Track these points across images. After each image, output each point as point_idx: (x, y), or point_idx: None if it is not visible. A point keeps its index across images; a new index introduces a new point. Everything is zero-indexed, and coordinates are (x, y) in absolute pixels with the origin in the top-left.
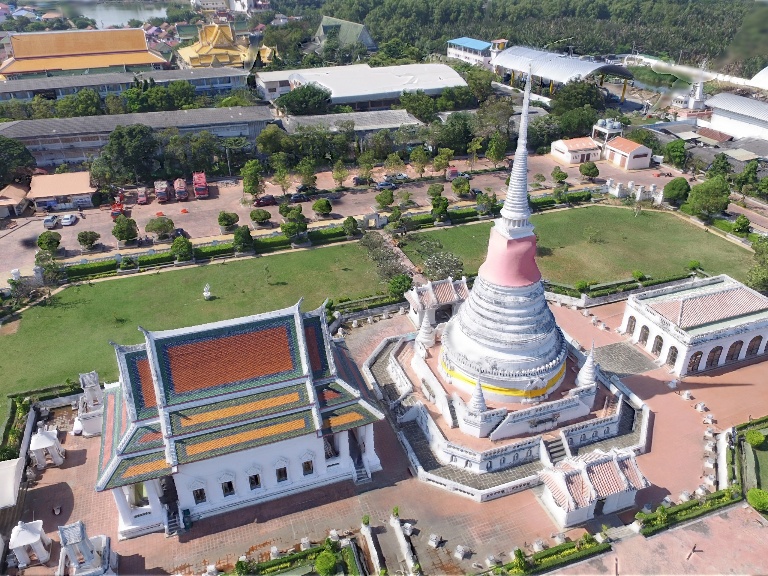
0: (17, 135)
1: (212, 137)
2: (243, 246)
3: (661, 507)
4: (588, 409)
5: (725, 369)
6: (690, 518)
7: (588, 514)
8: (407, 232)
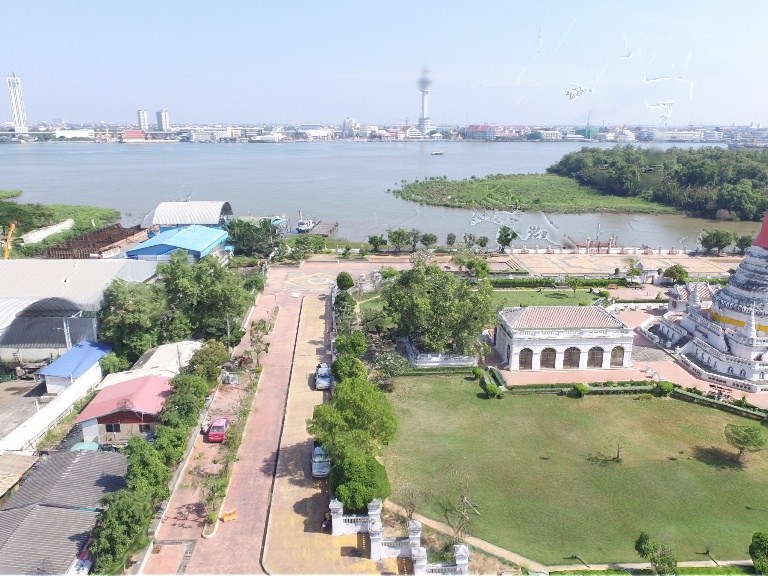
0: None
1: None
2: None
3: None
4: None
5: None
6: None
7: None
8: None
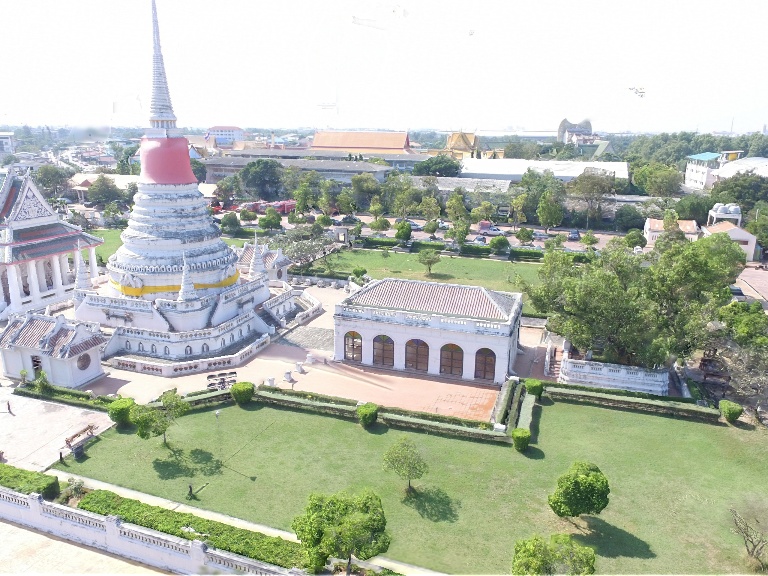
0: (211, 163)
1: (320, 177)
2: (230, 230)
3: (41, 372)
4: (166, 324)
5: (395, 373)
6: (65, 402)
7: (28, 373)
8: (362, 248)
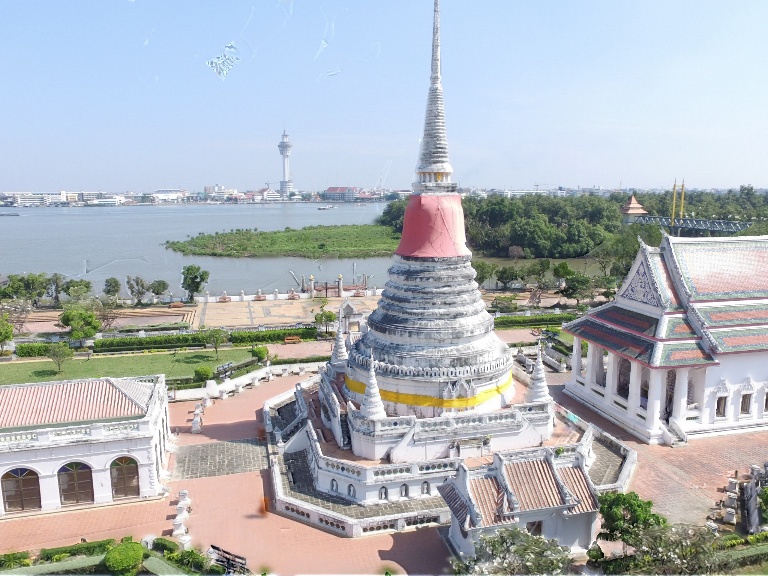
0: None
1: None
2: None
3: None
4: None
5: None
6: None
7: None
8: None
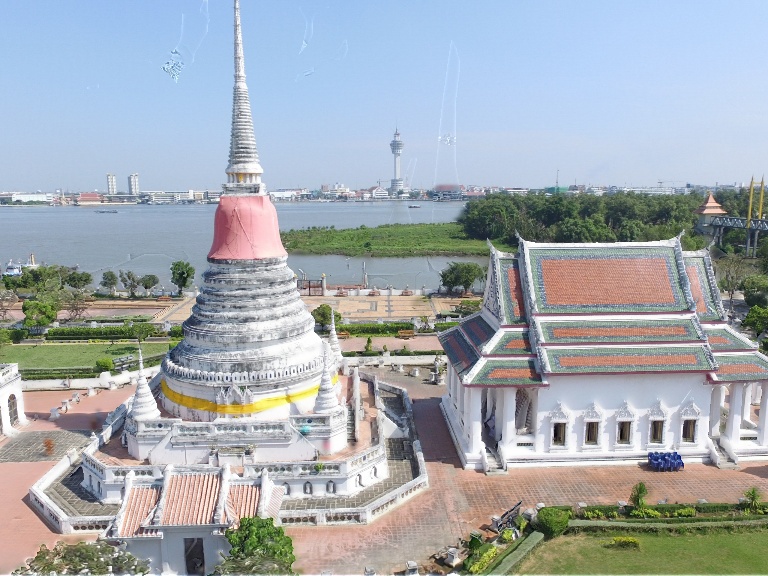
0: None
1: None
2: None
3: None
4: None
5: None
6: None
7: None
8: None
